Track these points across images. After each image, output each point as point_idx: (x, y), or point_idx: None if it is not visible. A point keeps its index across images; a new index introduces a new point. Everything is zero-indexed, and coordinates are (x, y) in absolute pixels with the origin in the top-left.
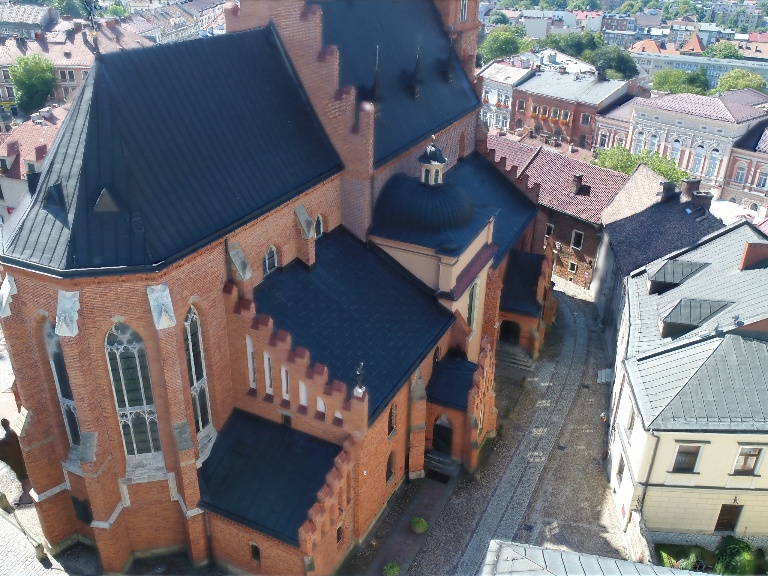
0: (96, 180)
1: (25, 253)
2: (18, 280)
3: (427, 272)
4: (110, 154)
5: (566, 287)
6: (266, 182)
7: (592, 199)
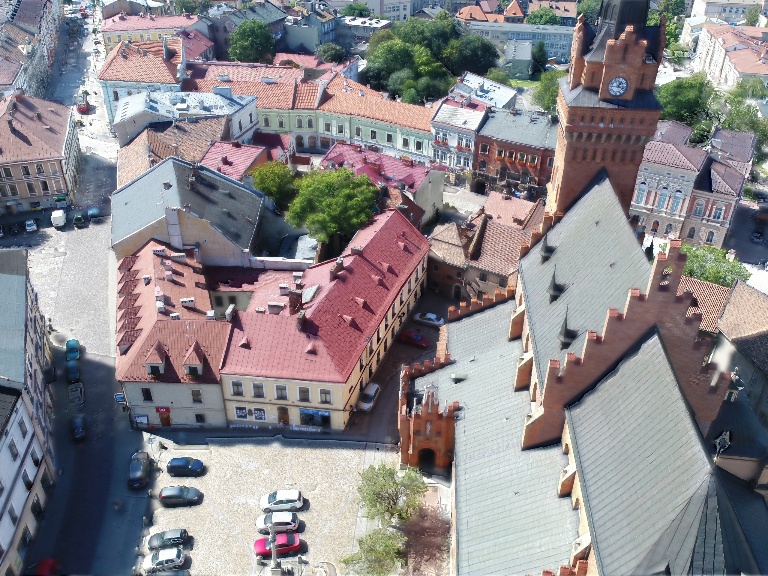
0: (733, 568)
1: None
2: None
3: (743, 471)
4: (735, 544)
5: None
6: (716, 476)
7: (702, 310)
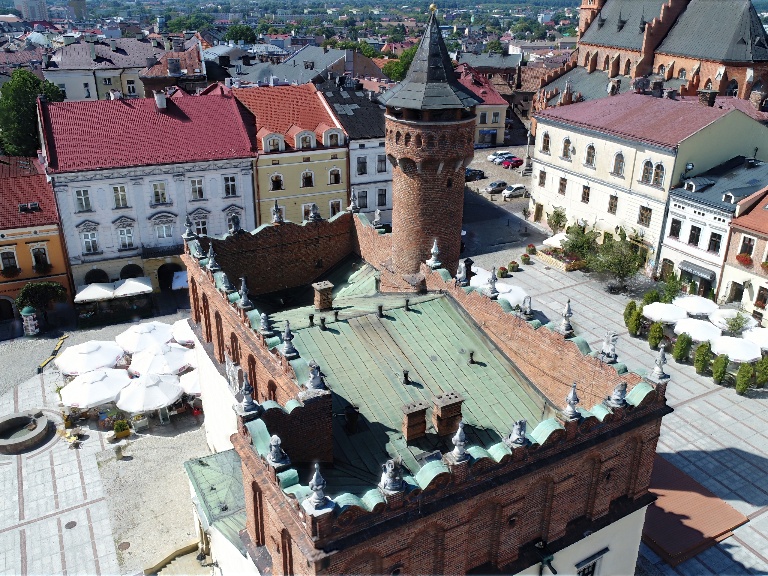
0: None
1: (759, 58)
2: (755, 68)
3: None
4: None
5: None
6: None
7: None
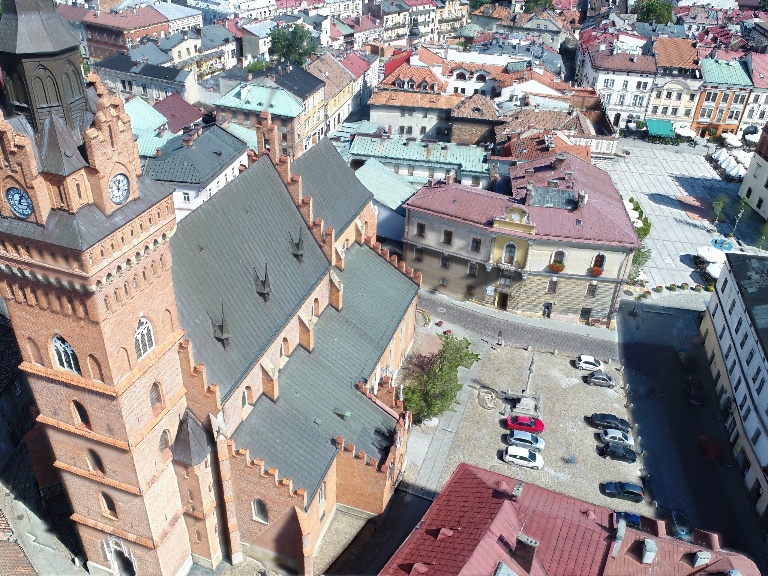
0: None
1: None
2: None
3: None
4: None
5: (6, 508)
6: None
7: None
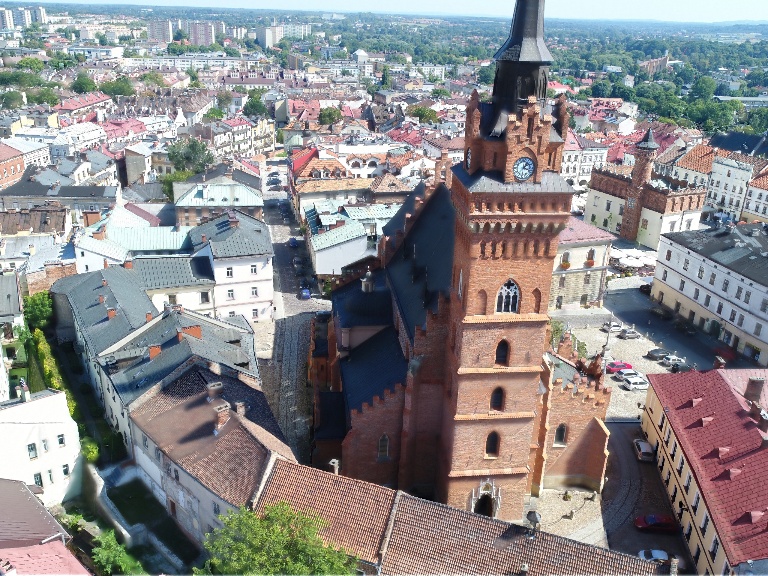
0: None
1: None
2: None
3: None
4: None
5: None
6: None
7: None
